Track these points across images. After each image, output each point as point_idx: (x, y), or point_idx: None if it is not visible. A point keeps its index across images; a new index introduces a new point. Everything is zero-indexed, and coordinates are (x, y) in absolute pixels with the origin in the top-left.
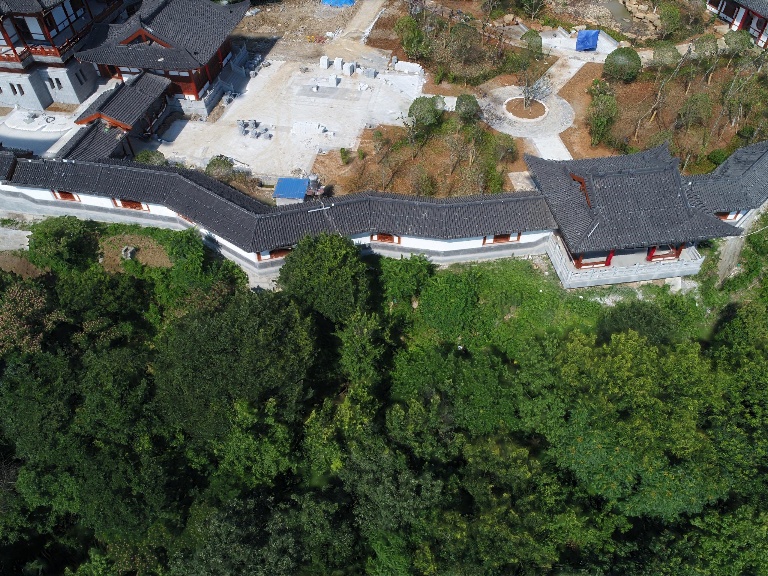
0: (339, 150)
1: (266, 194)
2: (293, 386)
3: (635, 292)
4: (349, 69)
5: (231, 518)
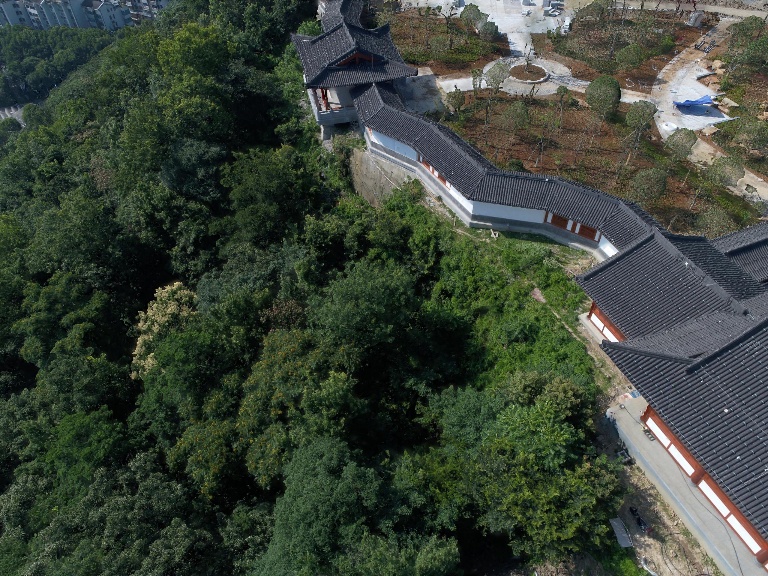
0: (437, 13)
1: (386, 0)
2: (232, 7)
3: (311, 113)
4: (543, 2)
5: (187, 22)
